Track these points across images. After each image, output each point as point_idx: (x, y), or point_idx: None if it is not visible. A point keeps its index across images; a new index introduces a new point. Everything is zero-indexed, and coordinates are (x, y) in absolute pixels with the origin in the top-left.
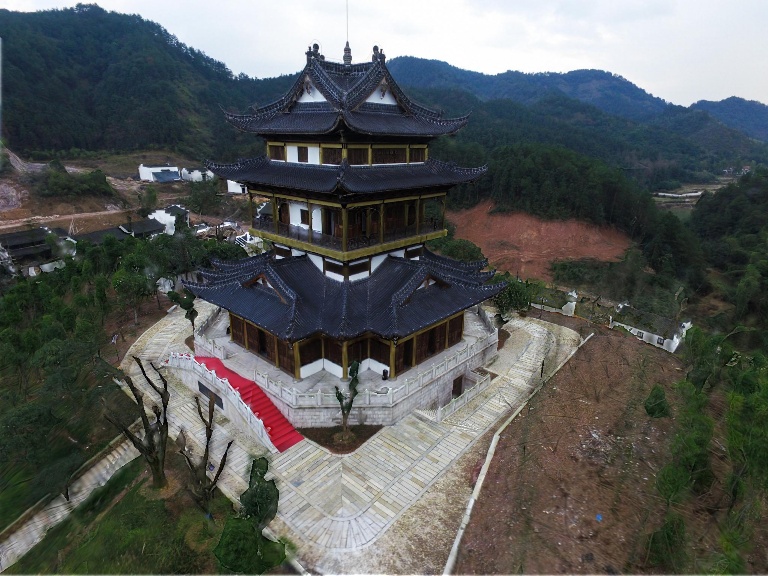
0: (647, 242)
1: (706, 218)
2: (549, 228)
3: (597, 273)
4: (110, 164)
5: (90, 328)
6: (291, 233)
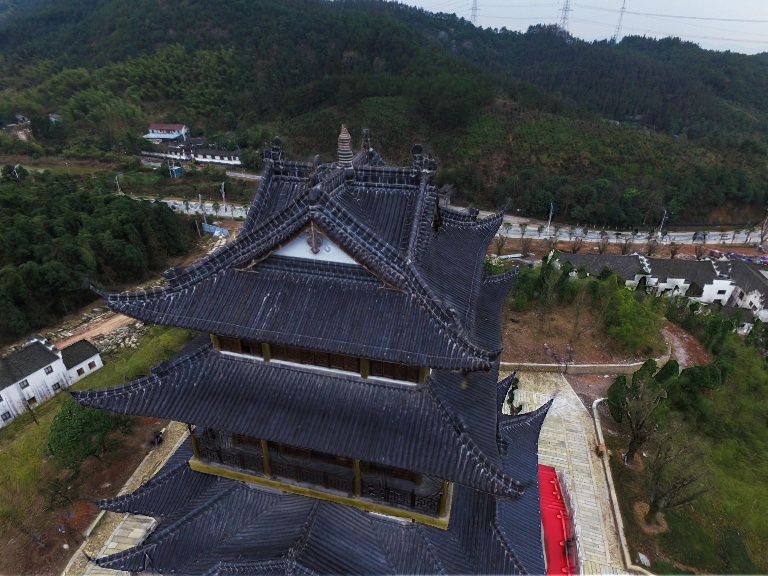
0: None
1: None
2: None
3: None
4: None
5: None
6: None
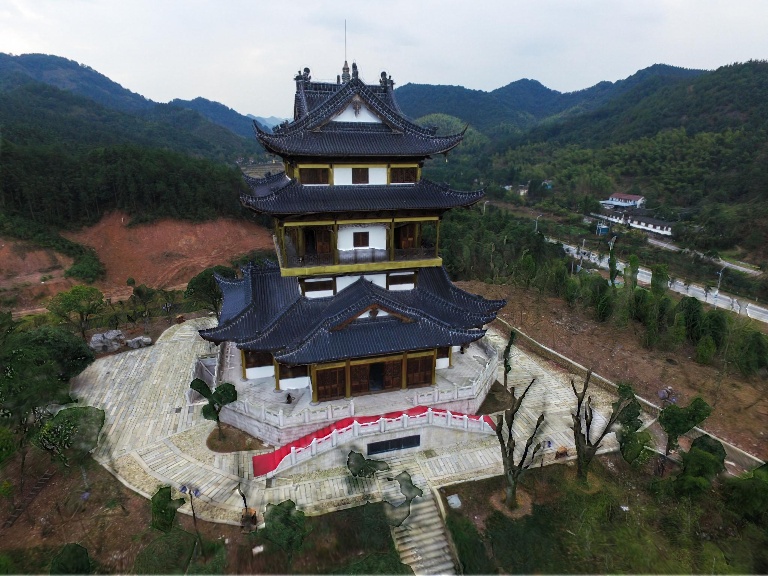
0: None
1: None
2: (204, 230)
3: (273, 260)
4: None
5: None
6: (361, 258)
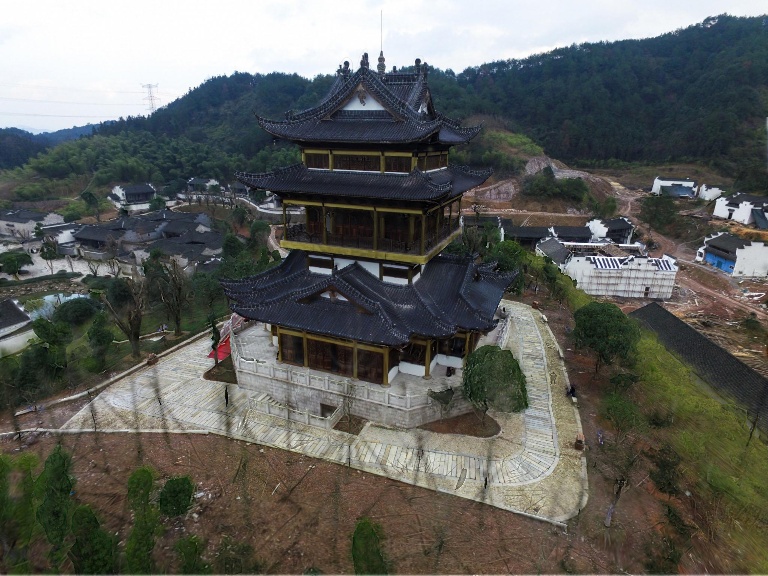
0: None
1: None
2: None
3: None
4: (633, 175)
5: None
6: None
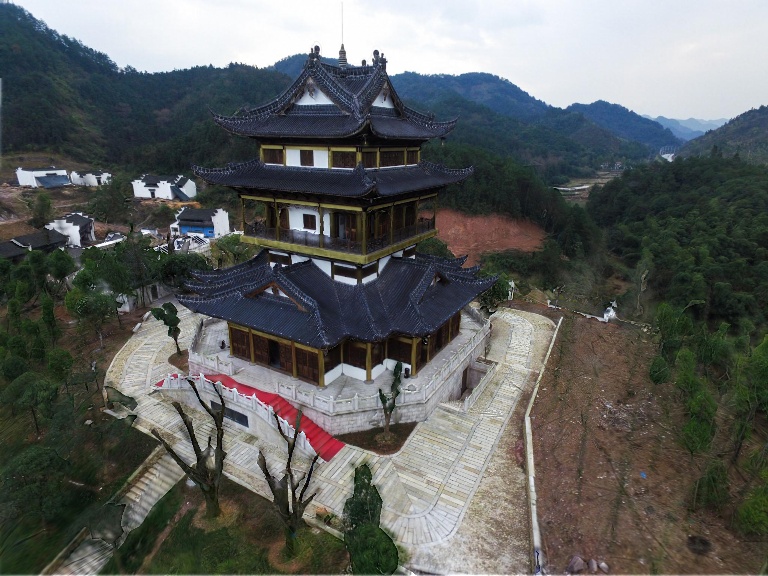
0: (558, 232)
1: (599, 209)
2: (474, 223)
3: (522, 263)
4: None
5: (64, 356)
6: (296, 239)
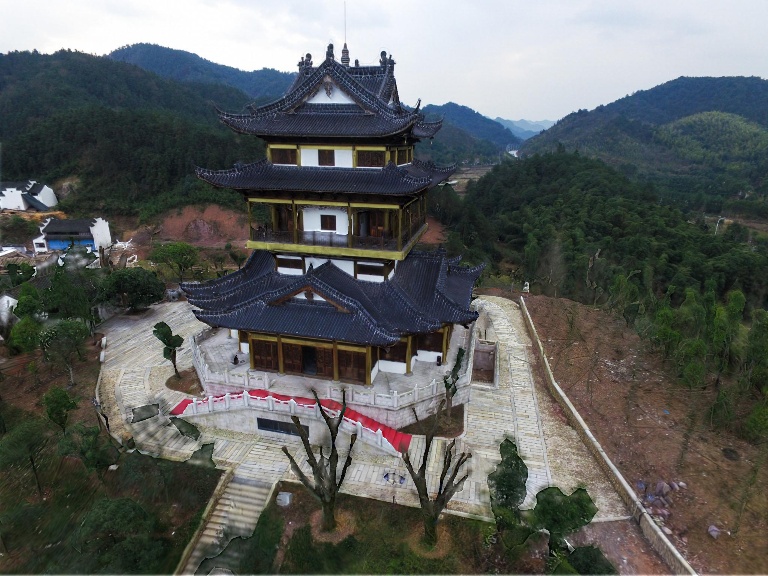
0: (454, 224)
1: (477, 201)
2: None
3: None
4: None
5: (62, 397)
6: (319, 240)
